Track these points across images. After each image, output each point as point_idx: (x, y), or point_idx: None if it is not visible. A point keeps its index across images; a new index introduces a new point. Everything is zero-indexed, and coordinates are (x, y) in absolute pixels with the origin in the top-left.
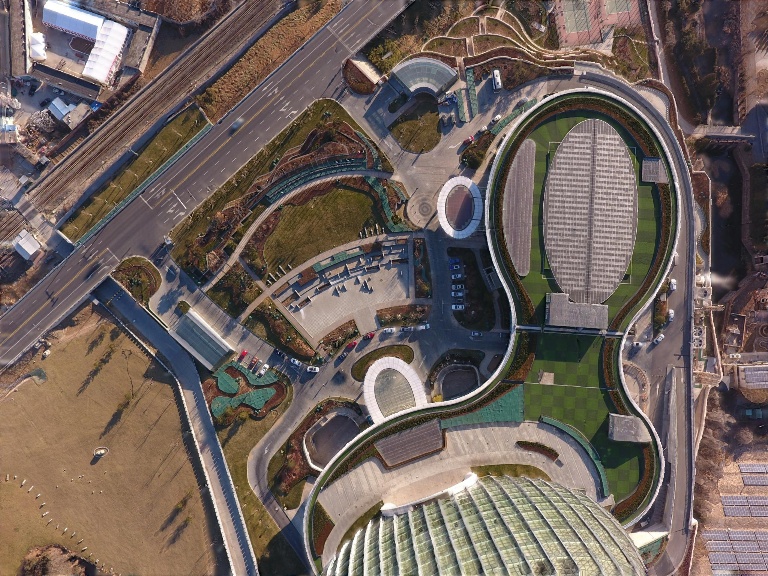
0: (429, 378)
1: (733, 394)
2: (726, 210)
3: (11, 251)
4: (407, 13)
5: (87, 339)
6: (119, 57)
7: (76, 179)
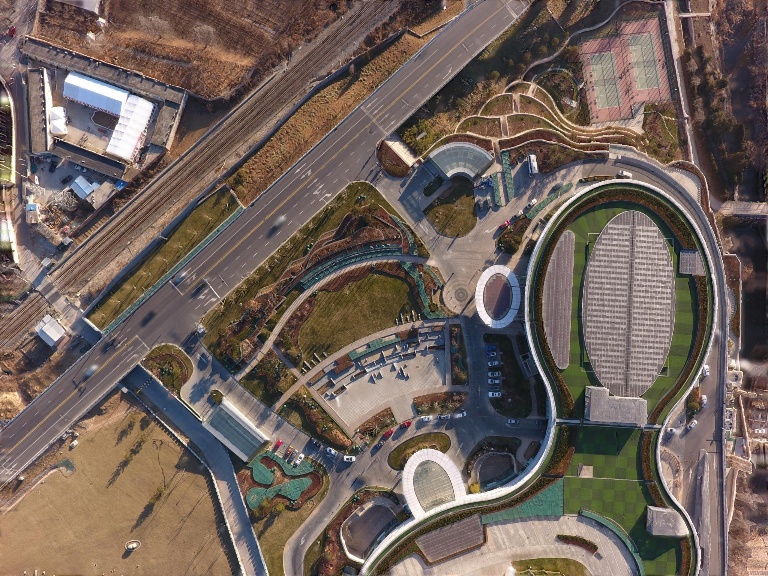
0: (466, 466)
1: (758, 469)
2: (751, 285)
3: (33, 335)
4: (440, 90)
5: (116, 428)
6: (144, 133)
7: (101, 260)
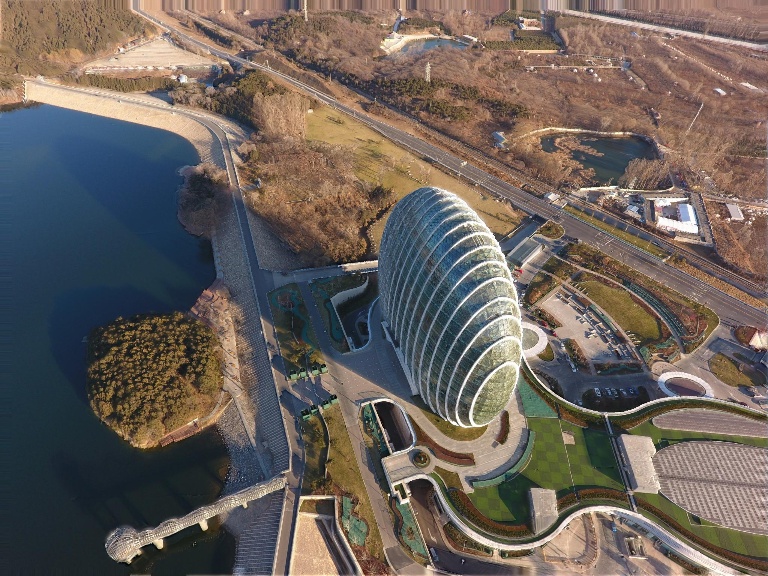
0: None
1: None
2: None
3: None
4: None
5: (509, 214)
6: None
7: None
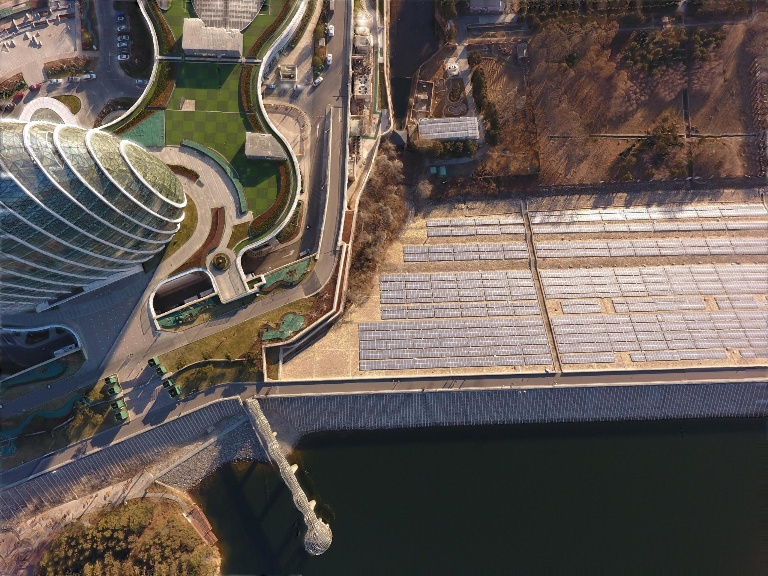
0: None
1: (422, 156)
2: None
3: None
4: None
5: None
6: None
7: None
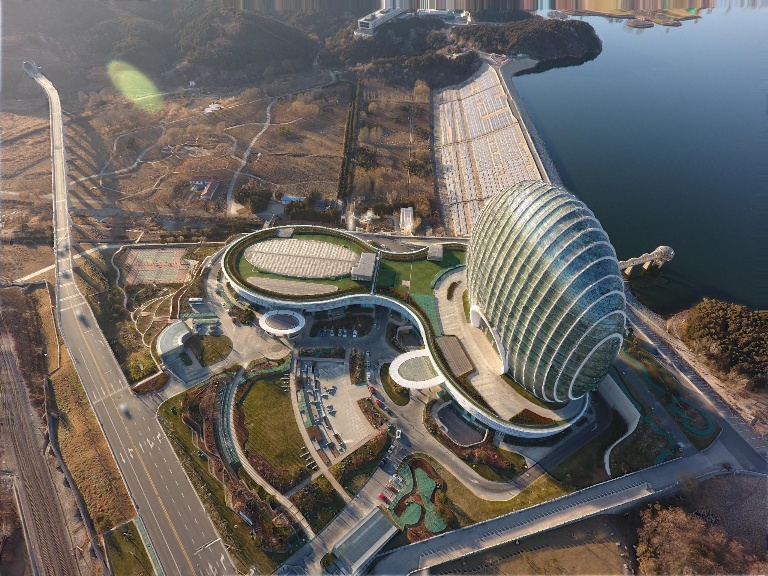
0: None
1: None
2: None
3: None
4: None
5: None
6: None
7: None
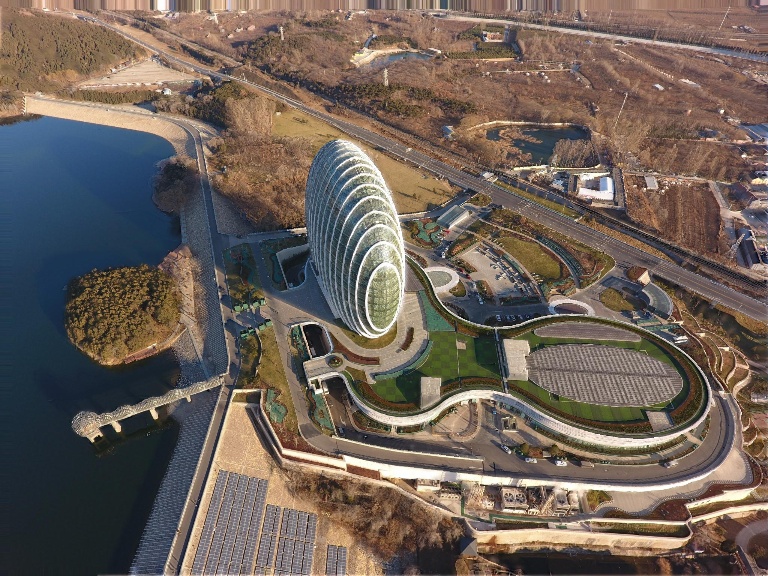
0: None
1: None
2: None
3: None
4: None
5: (445, 189)
6: None
7: None
